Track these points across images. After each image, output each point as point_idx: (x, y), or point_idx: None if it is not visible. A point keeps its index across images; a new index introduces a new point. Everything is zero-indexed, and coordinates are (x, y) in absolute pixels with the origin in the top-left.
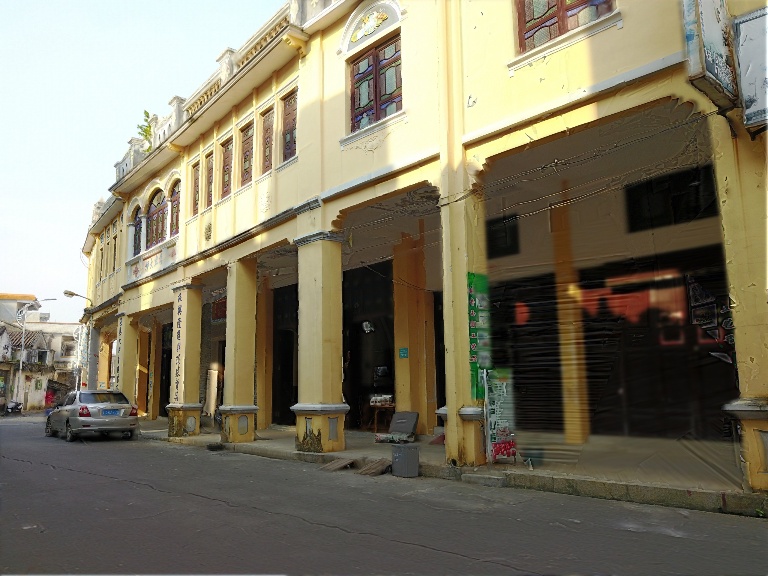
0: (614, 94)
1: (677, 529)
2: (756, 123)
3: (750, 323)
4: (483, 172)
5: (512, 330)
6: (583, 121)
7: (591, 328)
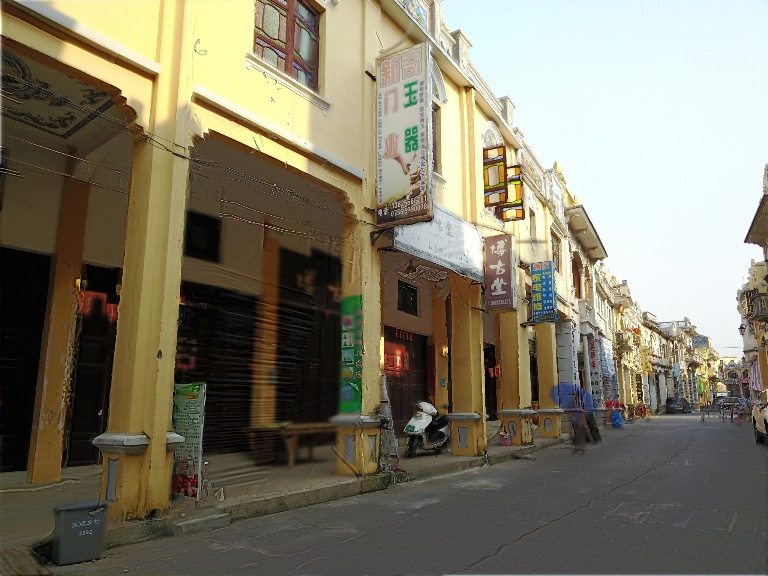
0: (320, 163)
1: (409, 502)
2: (399, 248)
3: None
4: (204, 142)
5: (218, 340)
6: (298, 166)
7: (285, 352)
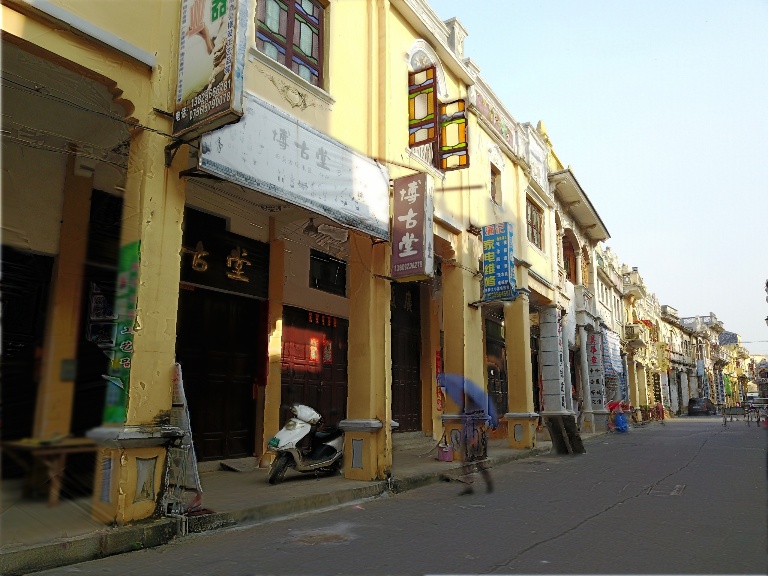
0: (53, 27)
1: None
2: (209, 170)
3: (148, 349)
4: None
5: None
6: None
7: None
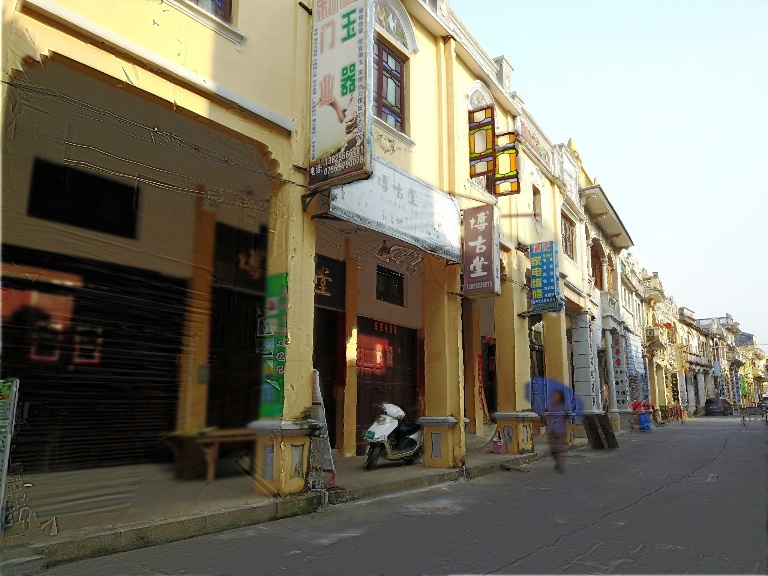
0: (228, 107)
1: (325, 534)
2: (337, 214)
3: (295, 358)
4: (40, 65)
5: (54, 322)
6: (194, 109)
7: (167, 340)
